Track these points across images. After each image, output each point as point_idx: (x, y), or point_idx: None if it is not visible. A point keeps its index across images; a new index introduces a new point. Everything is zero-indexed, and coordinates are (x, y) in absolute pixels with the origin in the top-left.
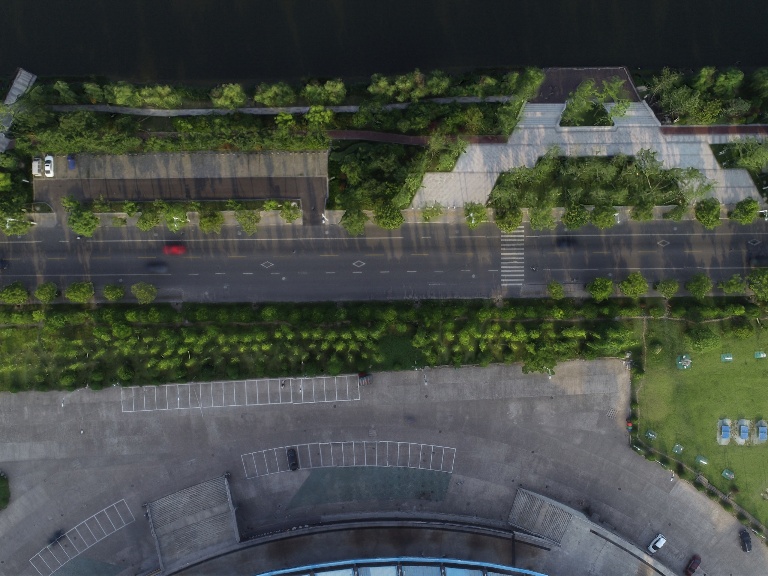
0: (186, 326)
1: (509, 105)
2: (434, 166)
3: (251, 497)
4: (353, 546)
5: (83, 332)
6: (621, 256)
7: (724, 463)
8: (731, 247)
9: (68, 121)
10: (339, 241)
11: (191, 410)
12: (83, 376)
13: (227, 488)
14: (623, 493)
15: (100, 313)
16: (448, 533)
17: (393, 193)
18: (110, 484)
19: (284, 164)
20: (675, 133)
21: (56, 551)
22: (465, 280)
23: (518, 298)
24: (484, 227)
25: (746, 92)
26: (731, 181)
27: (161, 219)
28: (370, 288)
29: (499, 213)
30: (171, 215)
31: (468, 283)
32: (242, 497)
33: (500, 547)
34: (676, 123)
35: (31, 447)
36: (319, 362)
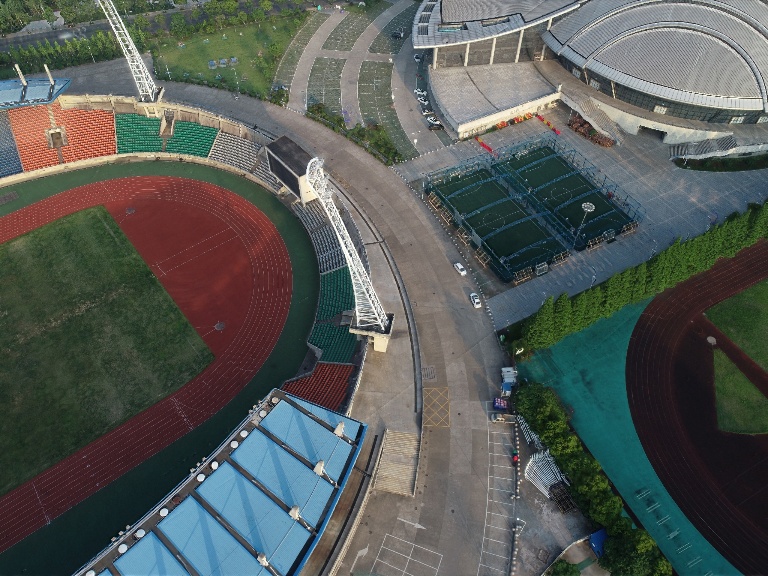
0: None
1: None
2: (35, 19)
3: None
4: None
5: None
6: None
7: (215, 74)
8: None
9: None
10: None
11: None
12: None
13: None
14: None
15: None
16: None
17: None
18: None
19: None
20: None
21: None
22: None
23: None
24: None
25: None
26: None
27: None
28: None
29: None
30: None
31: None
32: None
33: None
34: None
35: None
36: None
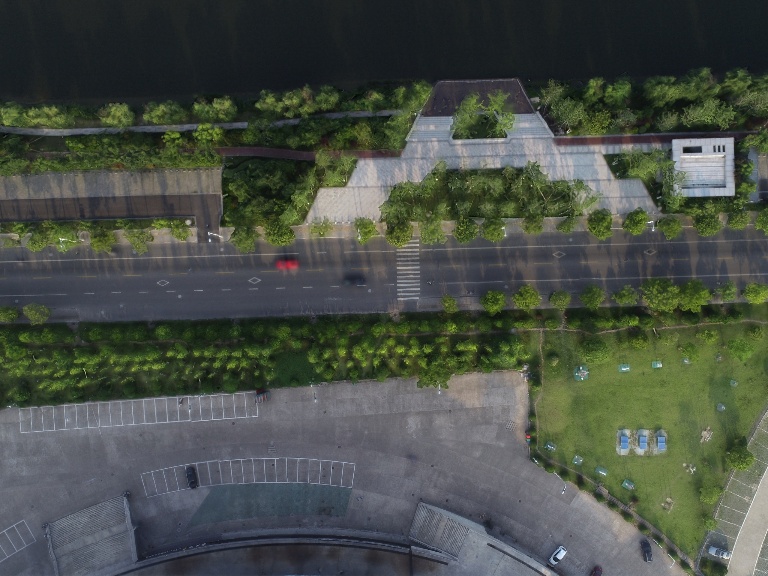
0: (82, 346)
1: (392, 120)
2: None
3: (151, 516)
4: (250, 564)
5: None
6: (517, 268)
7: (624, 473)
8: (627, 257)
9: None
10: (234, 258)
11: (89, 430)
12: None
13: (126, 507)
14: (524, 505)
15: None
16: (345, 549)
17: (282, 210)
18: (10, 505)
19: (178, 182)
20: (569, 144)
21: None
22: (361, 295)
23: (415, 312)
24: (379, 241)
25: (640, 102)
26: (625, 191)
27: (52, 240)
28: (266, 304)
29: (389, 228)
30: (58, 236)
31: (364, 298)
32: (142, 516)
33: (397, 562)
34: (569, 134)
35: None
36: (216, 379)
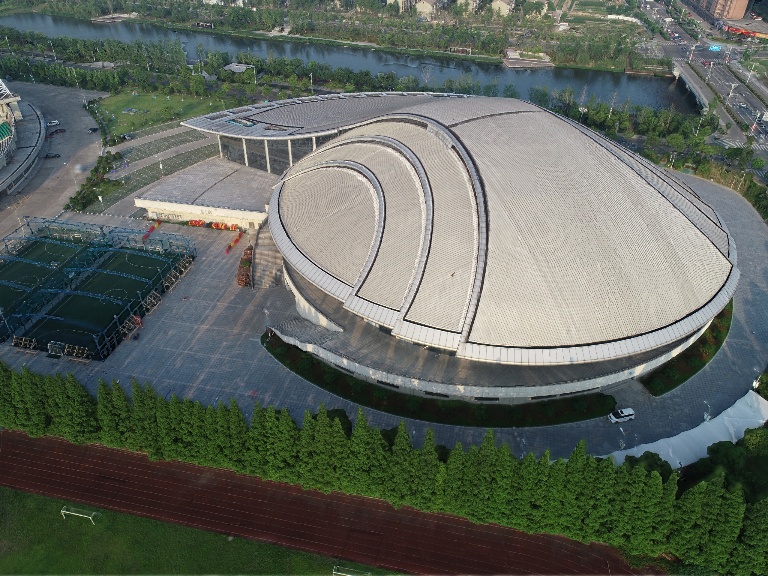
0: None
1: None
2: None
3: None
4: None
5: None
6: None
7: None
8: None
9: None
10: None
11: None
12: None
13: None
14: None
15: None
16: None
17: None
18: None
19: None
20: None
21: None
22: None
23: None
24: (106, 69)
25: None
26: None
27: None
28: None
29: None
30: None
31: None
32: None
33: None
34: None
35: None
36: None
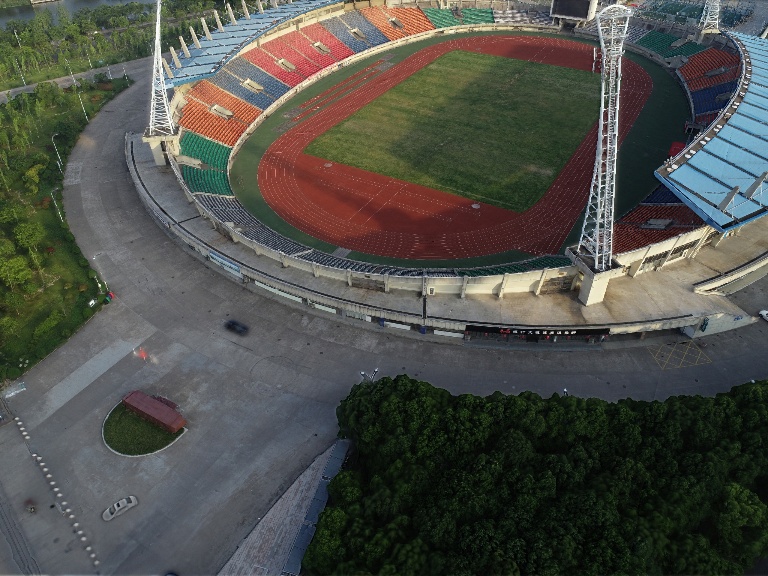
0: None
1: None
2: None
3: None
4: None
5: None
6: None
7: None
8: None
9: (102, 6)
10: None
11: None
12: None
13: None
14: None
15: None
16: None
17: None
18: None
19: None
20: None
21: None
22: None
23: None
24: None
25: None
26: None
27: None
28: None
29: None
30: (162, 7)
31: None
32: None
33: None
34: None
35: None
36: None
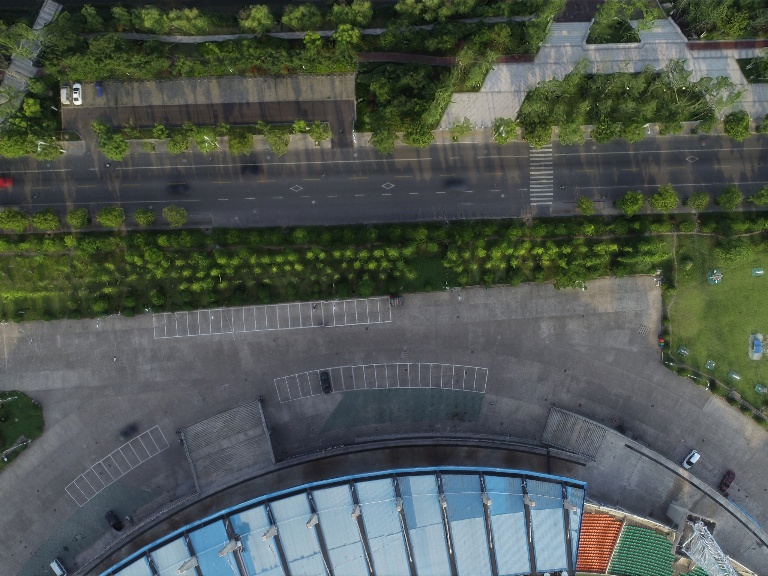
0: None
1: (538, 17)
2: (461, 86)
3: (285, 421)
4: (388, 465)
5: (114, 259)
6: (650, 173)
7: (756, 378)
8: (760, 162)
9: (97, 43)
10: (368, 163)
11: (223, 335)
12: (115, 303)
13: (261, 411)
14: (656, 410)
15: (131, 238)
16: (483, 450)
17: (422, 110)
18: (144, 411)
19: (311, 87)
20: (702, 49)
21: (91, 479)
22: (494, 200)
23: (548, 217)
24: (512, 146)
25: None
26: (758, 95)
27: (191, 142)
28: (400, 210)
29: (528, 129)
30: (202, 135)
31: (497, 203)
32: (276, 421)
33: (535, 463)
34: (703, 38)
35: (64, 375)
36: (350, 284)
